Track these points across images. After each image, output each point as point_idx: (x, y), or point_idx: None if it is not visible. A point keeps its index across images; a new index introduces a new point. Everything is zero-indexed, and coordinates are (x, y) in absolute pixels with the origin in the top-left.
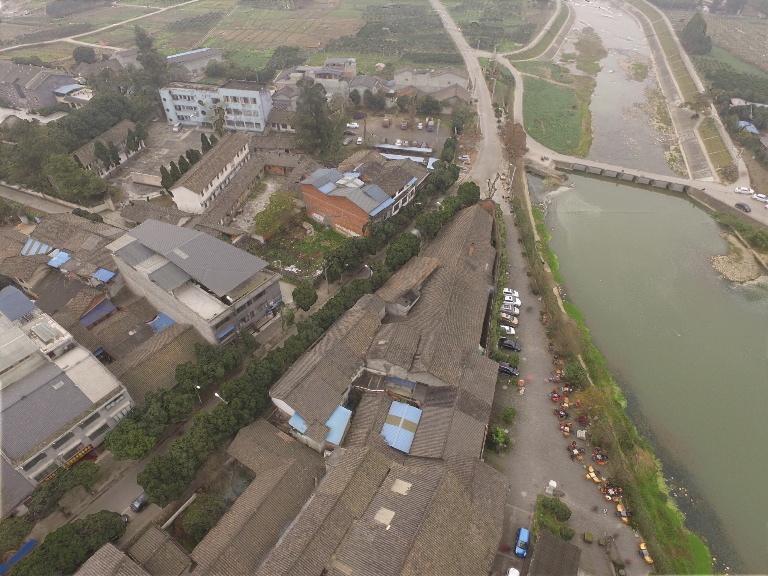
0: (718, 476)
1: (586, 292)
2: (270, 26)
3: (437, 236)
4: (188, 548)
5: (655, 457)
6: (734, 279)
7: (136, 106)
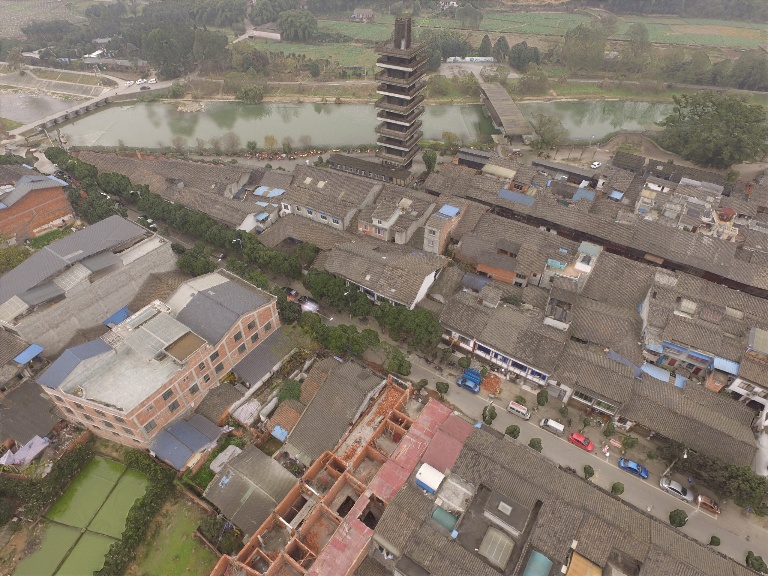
0: (306, 140)
1: None
2: None
3: None
4: None
5: None
6: (198, 109)
7: None
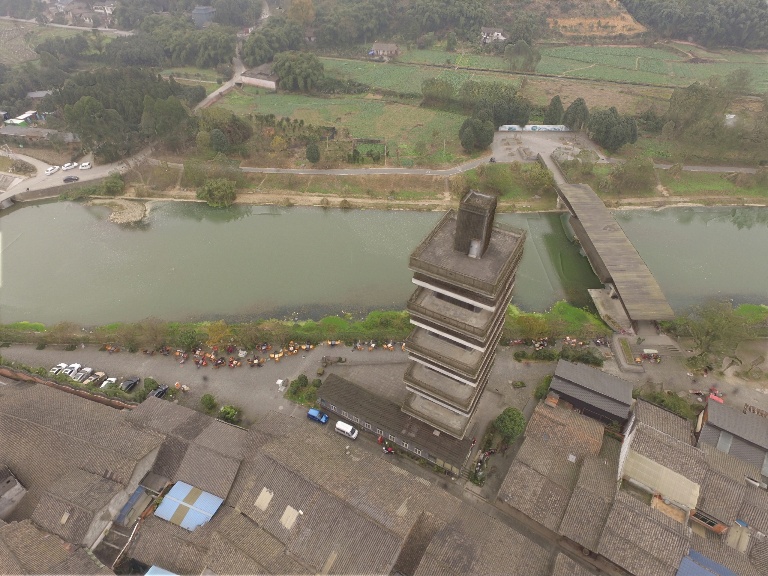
0: (289, 293)
1: (91, 312)
2: None
3: None
4: None
5: (268, 320)
6: (139, 218)
7: None
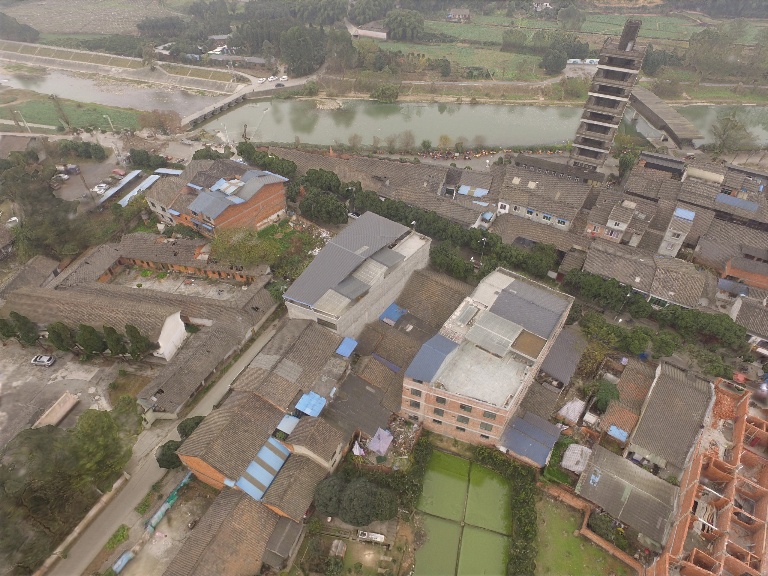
0: (460, 140)
1: None
2: None
3: None
4: (558, 268)
5: None
6: (338, 107)
7: None
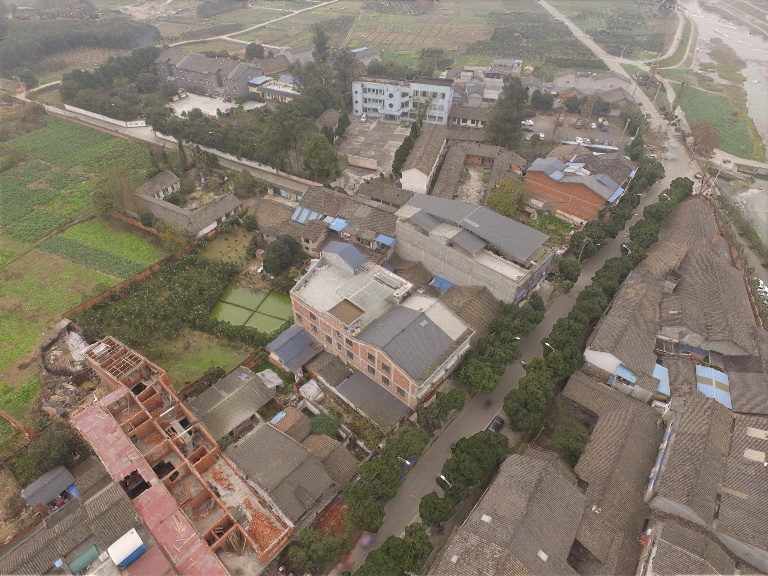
0: None
1: None
2: (402, 30)
3: (662, 226)
4: None
5: None
6: None
7: (336, 97)
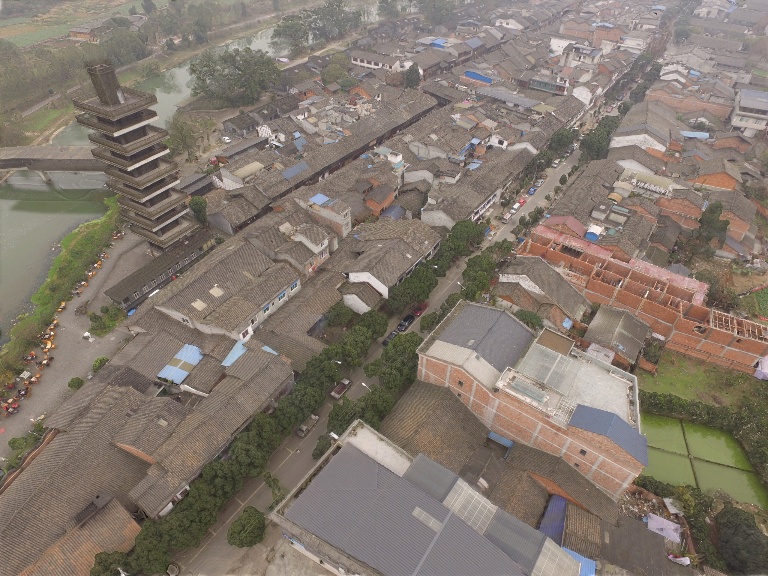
0: None
1: None
2: None
3: None
4: None
5: None
6: None
7: None
